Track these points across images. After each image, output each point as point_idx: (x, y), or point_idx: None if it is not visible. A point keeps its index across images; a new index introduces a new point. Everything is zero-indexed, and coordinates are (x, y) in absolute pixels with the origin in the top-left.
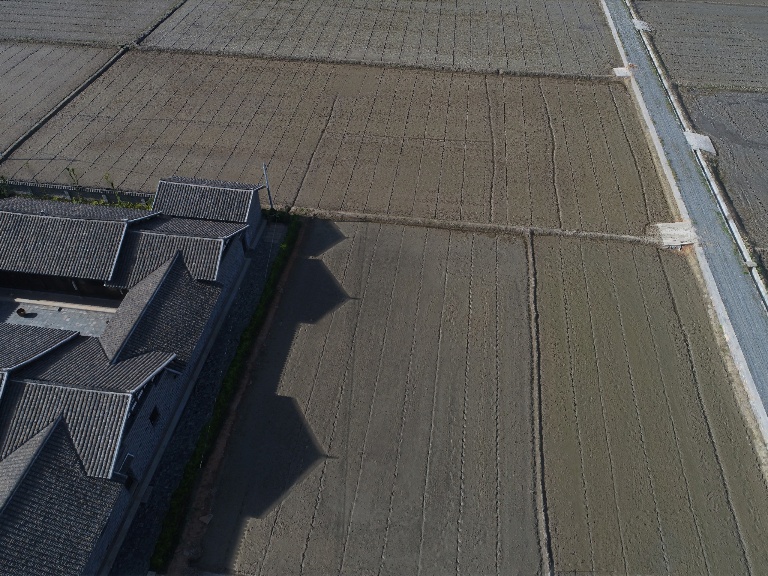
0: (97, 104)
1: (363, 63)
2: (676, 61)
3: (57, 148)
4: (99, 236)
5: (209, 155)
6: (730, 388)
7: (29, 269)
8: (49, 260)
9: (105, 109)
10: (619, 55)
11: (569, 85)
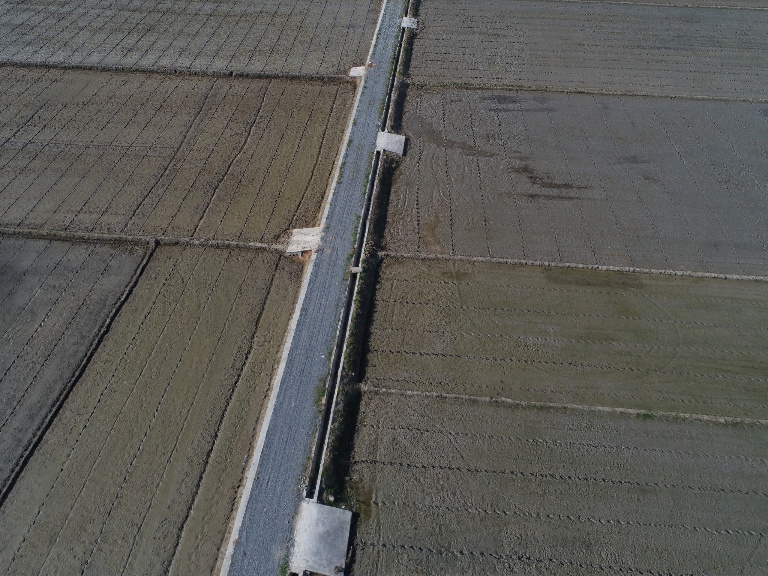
0: None
1: (95, 68)
2: (424, 59)
3: None
4: None
5: None
6: (261, 403)
7: None
8: None
9: None
10: (368, 54)
11: (298, 86)
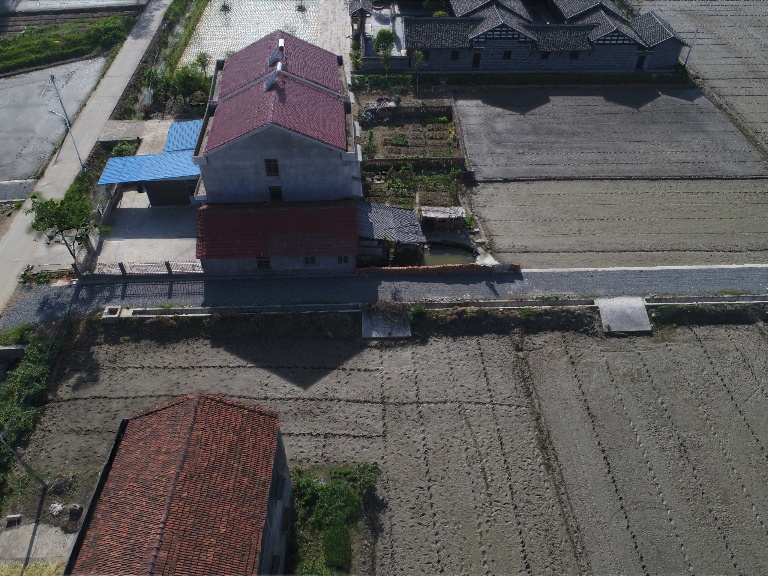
0: (723, 2)
1: None
2: None
3: (666, 4)
4: (587, 2)
5: (718, 44)
6: None
7: (556, 2)
8: (565, 2)
9: (722, 6)
10: None
11: None
